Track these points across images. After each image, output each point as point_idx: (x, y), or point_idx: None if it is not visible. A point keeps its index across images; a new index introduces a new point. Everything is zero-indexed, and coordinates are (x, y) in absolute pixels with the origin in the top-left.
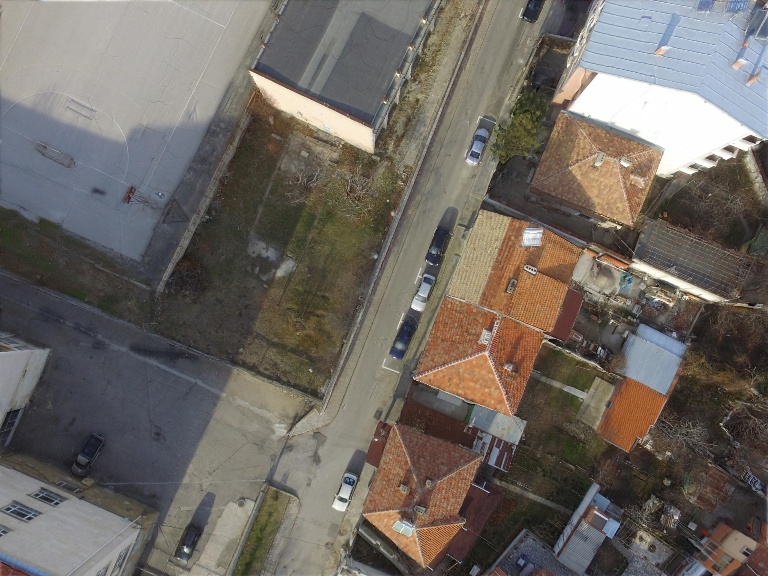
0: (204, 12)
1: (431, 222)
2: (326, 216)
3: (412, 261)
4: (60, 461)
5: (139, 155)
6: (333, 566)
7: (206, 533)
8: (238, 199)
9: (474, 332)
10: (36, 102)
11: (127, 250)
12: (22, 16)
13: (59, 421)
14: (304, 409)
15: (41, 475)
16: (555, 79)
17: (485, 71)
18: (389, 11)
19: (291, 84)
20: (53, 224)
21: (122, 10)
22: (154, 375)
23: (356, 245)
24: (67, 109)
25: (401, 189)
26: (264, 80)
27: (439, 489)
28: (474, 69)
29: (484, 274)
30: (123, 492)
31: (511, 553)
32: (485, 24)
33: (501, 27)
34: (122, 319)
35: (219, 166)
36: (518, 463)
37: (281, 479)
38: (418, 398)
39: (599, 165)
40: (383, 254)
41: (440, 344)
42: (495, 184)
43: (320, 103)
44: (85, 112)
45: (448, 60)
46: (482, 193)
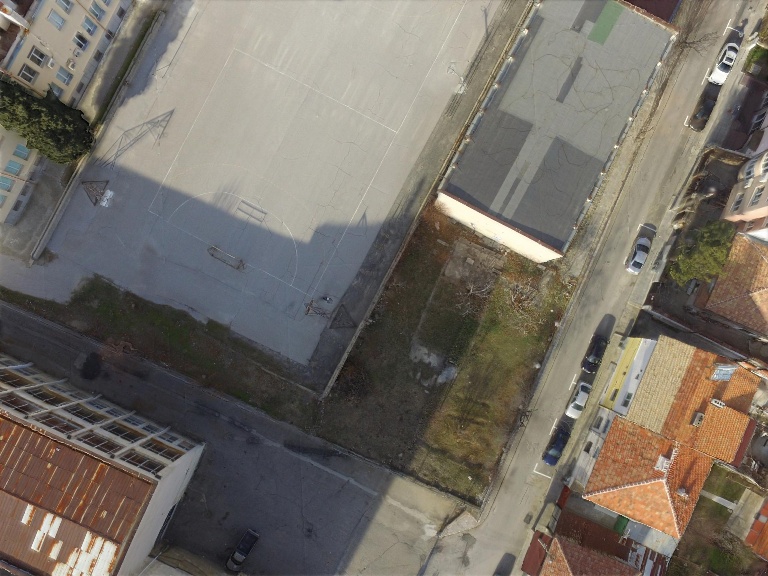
0: (376, 116)
1: (587, 329)
2: (489, 324)
3: (567, 367)
4: (213, 554)
5: (308, 259)
6: None
7: None
8: (402, 304)
9: (649, 457)
10: (206, 202)
11: (294, 354)
12: (194, 114)
13: (213, 514)
14: (455, 511)
15: (202, 573)
16: (726, 195)
17: (647, 178)
18: (582, 136)
19: (482, 207)
20: (221, 325)
21: (294, 112)
22: (307, 472)
23: (518, 354)
24: (237, 210)
25: (566, 300)
26: (453, 201)
27: None
28: (636, 176)
29: (666, 403)
30: None
31: None
32: (650, 131)
33: (665, 134)
34: (285, 421)
35: (388, 273)
36: (671, 575)
37: None
38: (569, 504)
39: None
40: (546, 365)
41: (611, 465)
42: None
43: (512, 228)
44: (255, 214)
45: (618, 171)
46: (640, 302)
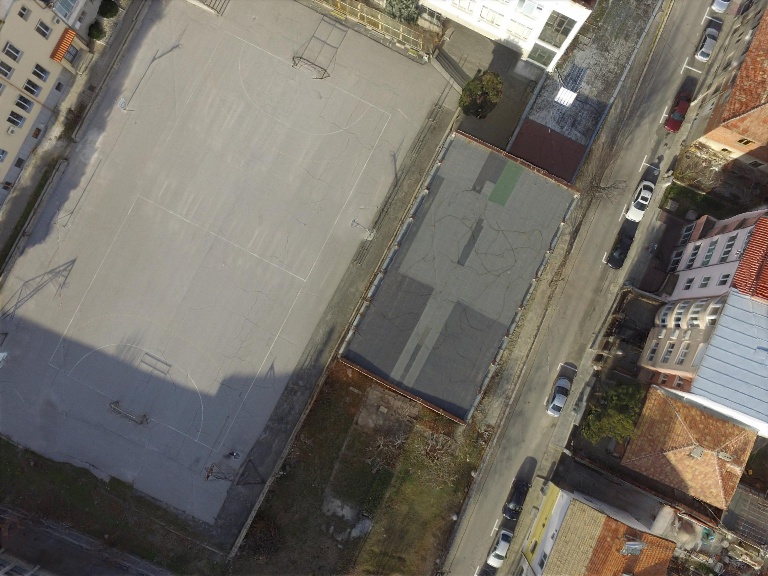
0: (284, 264)
1: (509, 472)
2: (404, 474)
3: (488, 512)
4: None
5: (214, 413)
6: None
7: None
8: (313, 454)
9: None
10: (109, 355)
11: (199, 513)
12: (96, 264)
13: None
14: None
15: None
16: (643, 340)
17: (567, 316)
18: (485, 300)
19: (382, 375)
20: (123, 483)
21: (200, 260)
22: None
23: (434, 505)
24: (141, 363)
25: (482, 448)
26: None
27: None
28: (555, 314)
29: (577, 574)
30: None
31: None
32: (568, 268)
33: (584, 271)
34: None
35: (297, 427)
36: None
37: None
38: None
39: None
40: (463, 517)
41: None
42: None
43: (413, 398)
44: (159, 366)
45: (533, 315)
46: (562, 444)
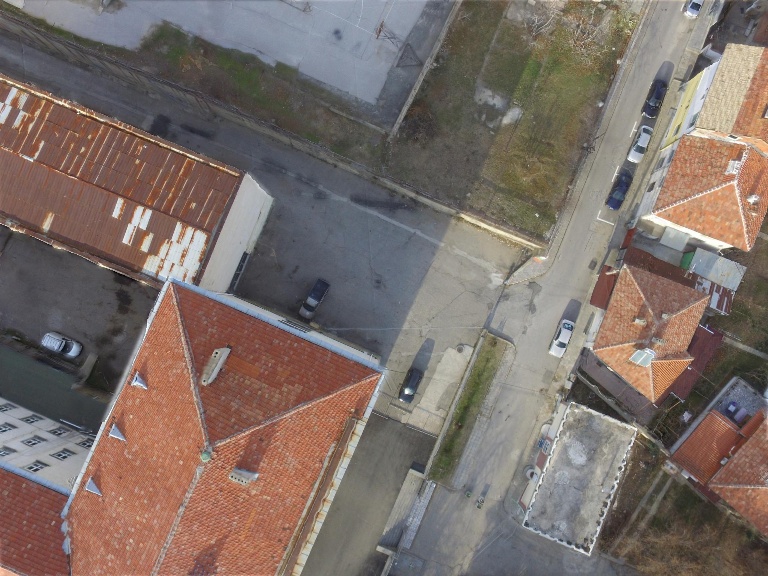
0: None
1: (647, 76)
2: (552, 64)
3: (627, 115)
4: (285, 306)
5: None
6: (548, 411)
7: (426, 377)
8: (465, 47)
9: (719, 165)
10: None
11: (362, 93)
12: None
13: (283, 268)
14: (521, 259)
15: (277, 313)
16: None
17: None
18: None
19: None
20: (289, 67)
21: None
22: (374, 225)
23: (582, 93)
24: None
25: (627, 37)
26: None
27: (673, 324)
28: None
29: (736, 103)
30: (346, 337)
31: (723, 399)
32: None
33: None
34: (354, 163)
35: (453, 10)
36: (737, 308)
37: (498, 327)
38: None
39: None
40: (610, 101)
41: (680, 179)
42: None
43: None
44: None
45: None
46: (699, 47)
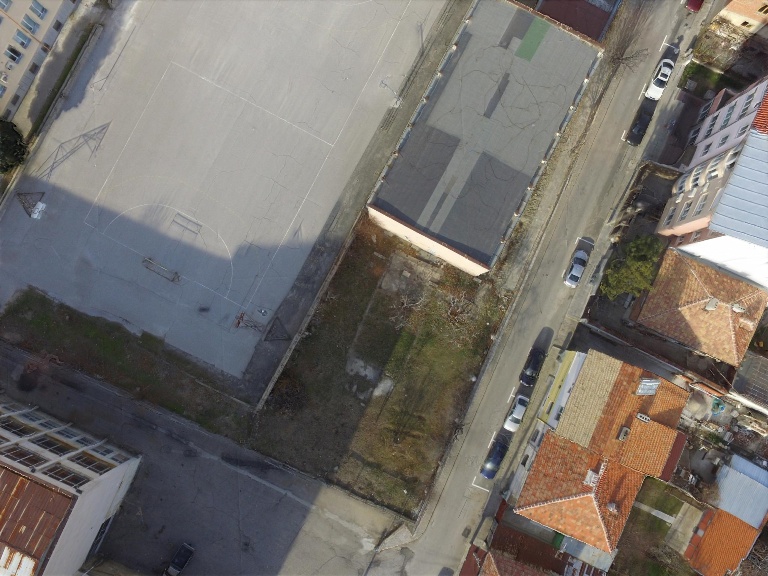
0: (312, 130)
1: (526, 341)
2: (425, 337)
3: (506, 380)
4: (149, 568)
5: (243, 271)
6: None
7: None
8: (338, 316)
9: (579, 471)
10: (142, 214)
11: (228, 366)
12: (130, 127)
13: (149, 528)
14: (393, 524)
15: None
16: (660, 209)
17: (585, 192)
18: (509, 151)
19: (409, 222)
20: (155, 337)
21: (231, 125)
22: (245, 485)
23: (454, 367)
24: (173, 222)
25: (501, 313)
26: (382, 215)
27: None
28: (574, 190)
29: (594, 417)
30: None
31: None
32: (587, 145)
33: (603, 149)
34: (219, 433)
35: (323, 286)
36: None
37: None
38: (507, 517)
39: (710, 309)
40: (482, 378)
41: (542, 479)
42: (592, 306)
43: (439, 243)
44: (190, 226)
45: (553, 185)
46: (578, 315)
